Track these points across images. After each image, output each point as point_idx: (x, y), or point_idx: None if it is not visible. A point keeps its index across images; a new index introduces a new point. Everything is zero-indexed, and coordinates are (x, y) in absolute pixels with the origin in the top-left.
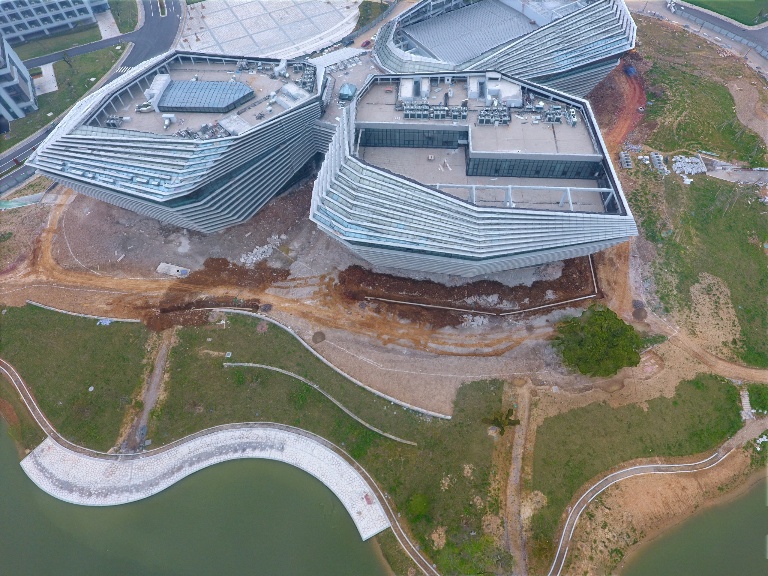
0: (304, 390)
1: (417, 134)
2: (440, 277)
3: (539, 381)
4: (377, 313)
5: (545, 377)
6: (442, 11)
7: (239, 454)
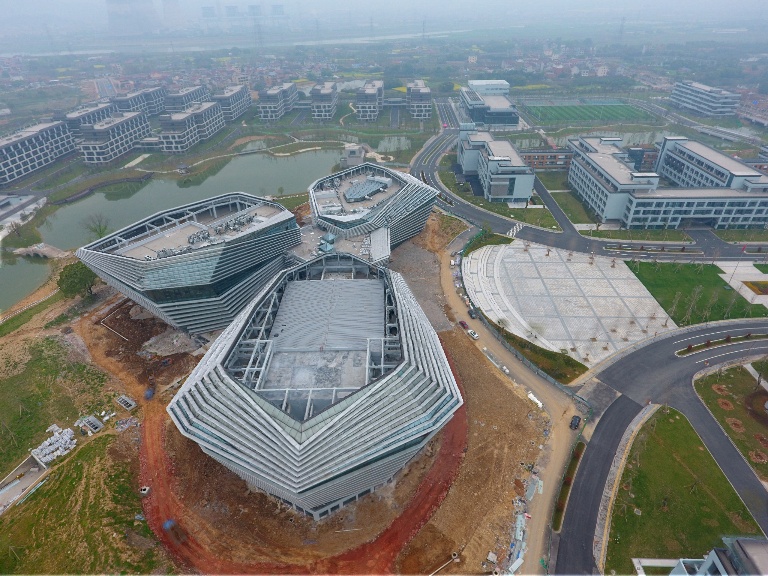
0: None
1: None
2: None
3: None
4: None
5: None
6: None
7: None
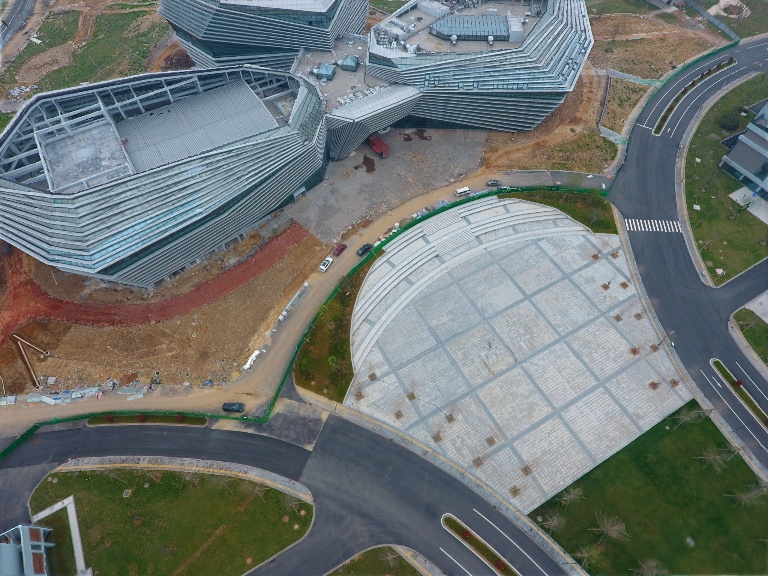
0: None
1: None
2: None
3: None
4: None
5: None
6: None
7: None
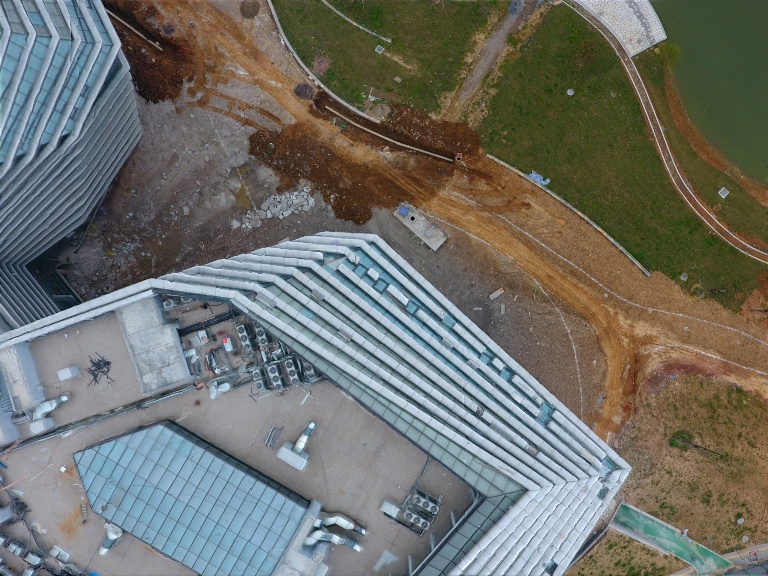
0: None
1: None
2: None
3: None
4: (155, 8)
5: None
6: None
7: None
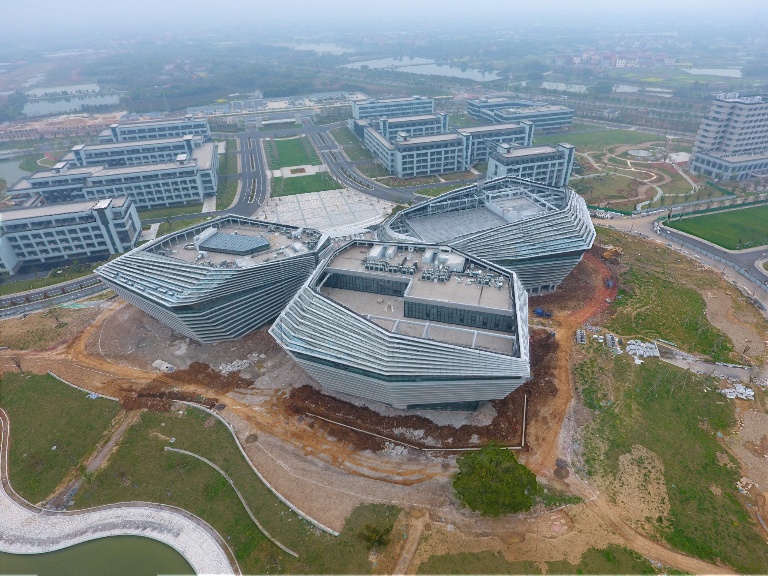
0: (220, 483)
1: (372, 282)
2: (378, 407)
3: (438, 517)
4: (310, 427)
5: (445, 515)
6: (442, 212)
7: (139, 531)
